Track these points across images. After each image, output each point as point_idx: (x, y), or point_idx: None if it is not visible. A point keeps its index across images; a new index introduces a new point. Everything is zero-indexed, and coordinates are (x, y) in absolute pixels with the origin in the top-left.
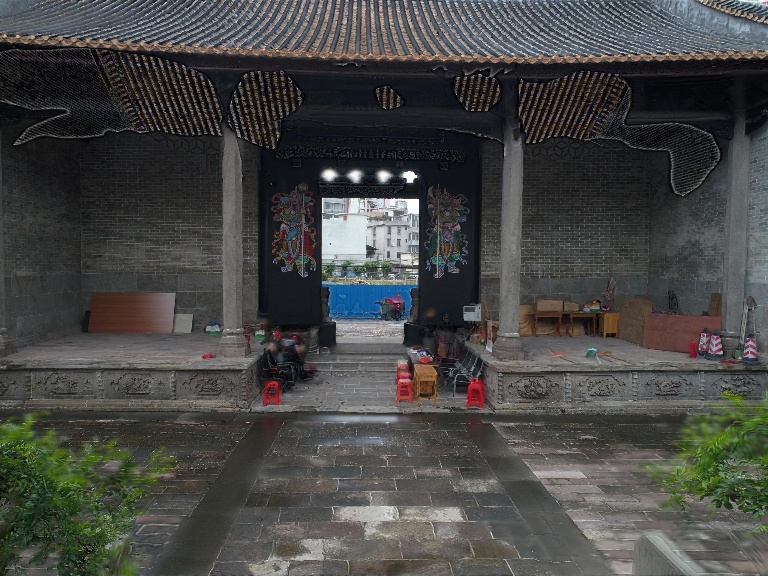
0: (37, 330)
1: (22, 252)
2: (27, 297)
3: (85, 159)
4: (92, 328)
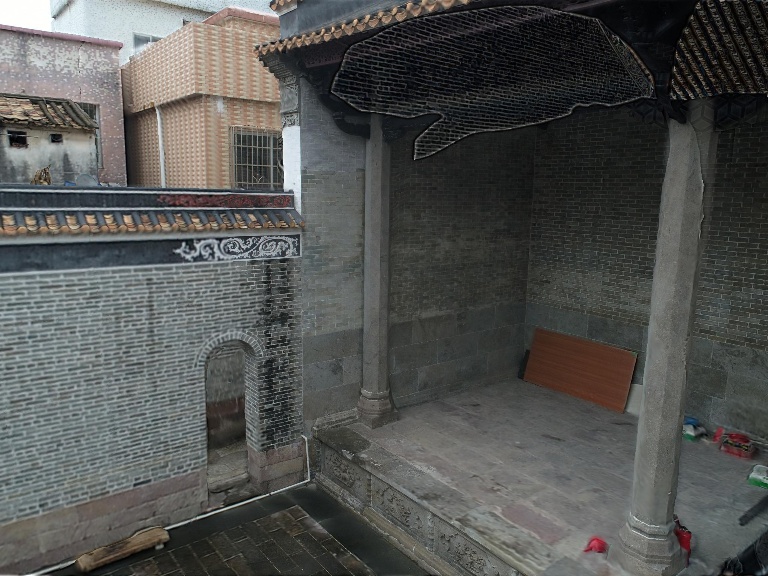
0: (449, 379)
1: (431, 288)
2: (436, 342)
3: (541, 151)
4: (528, 375)
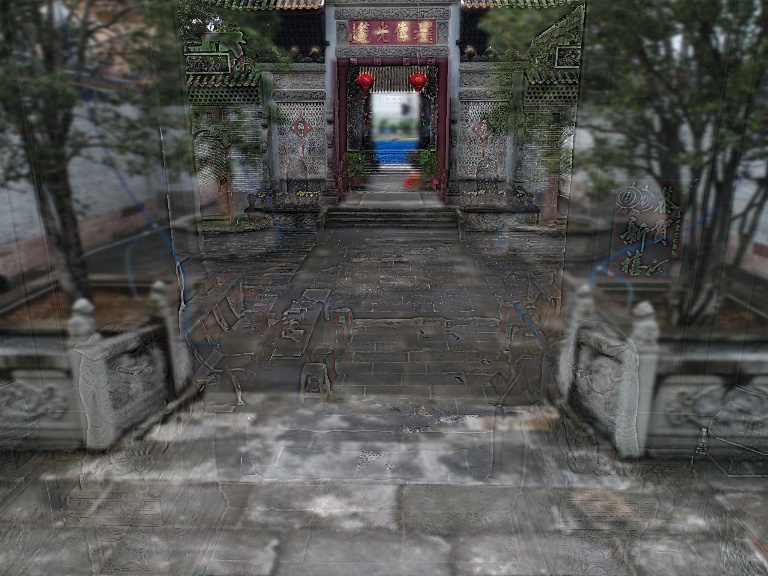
0: None
1: None
2: None
3: None
4: None
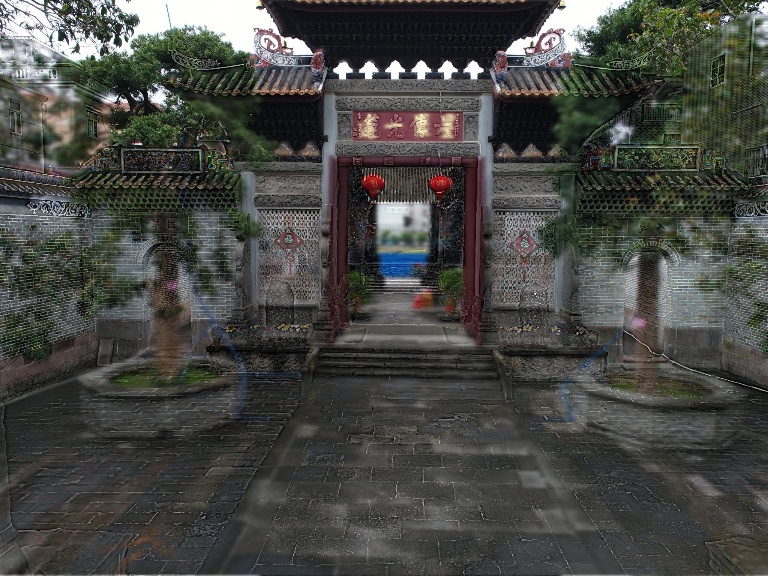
0: None
1: None
2: None
3: None
4: None
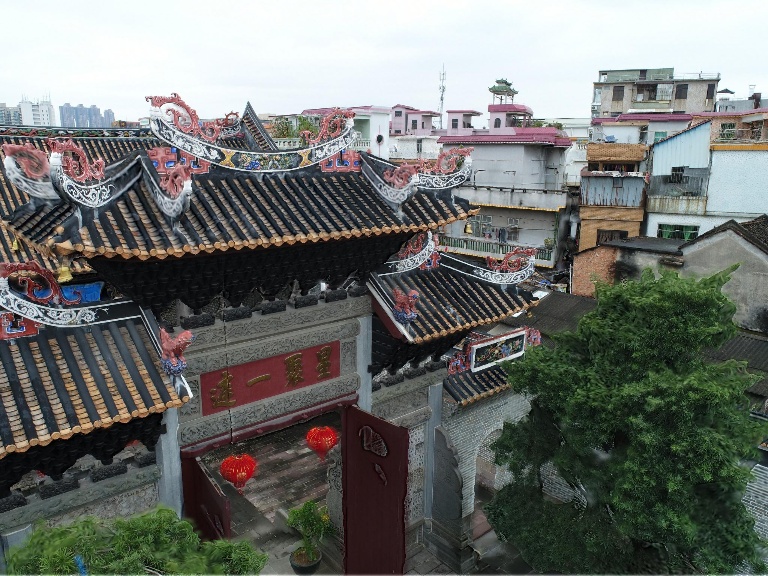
0: None
1: None
2: None
3: None
4: None
